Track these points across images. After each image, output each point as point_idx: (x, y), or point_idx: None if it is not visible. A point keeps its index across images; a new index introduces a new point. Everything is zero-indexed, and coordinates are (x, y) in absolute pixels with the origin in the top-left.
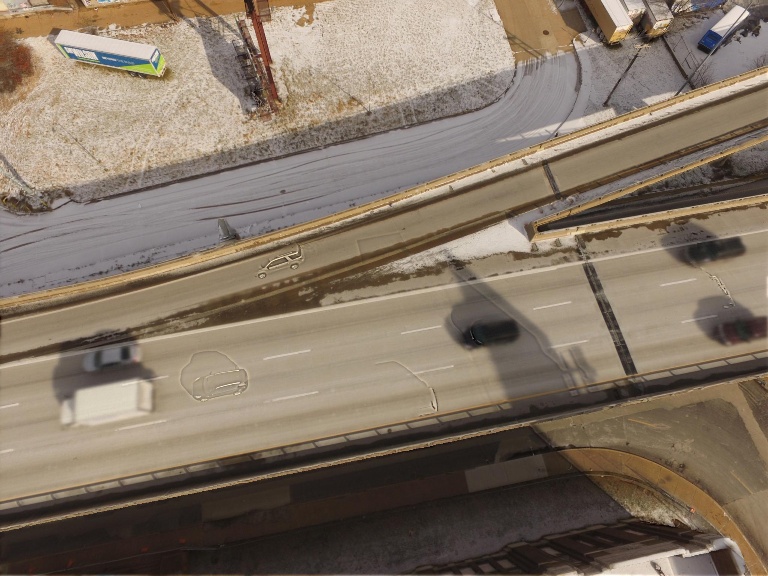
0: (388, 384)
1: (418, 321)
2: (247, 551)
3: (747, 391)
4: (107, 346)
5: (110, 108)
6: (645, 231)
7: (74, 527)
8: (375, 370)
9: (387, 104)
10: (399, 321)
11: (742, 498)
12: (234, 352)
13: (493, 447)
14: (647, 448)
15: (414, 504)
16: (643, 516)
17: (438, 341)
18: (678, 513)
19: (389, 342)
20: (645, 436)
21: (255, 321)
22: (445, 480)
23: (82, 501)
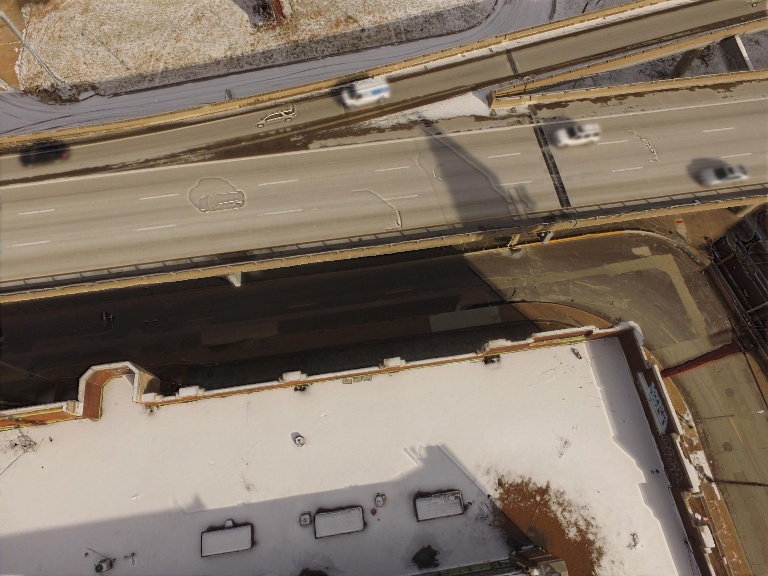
0: (361, 206)
1: (390, 162)
2: (238, 368)
3: (681, 264)
4: (128, 171)
5: (133, 18)
6: (589, 104)
7: (91, 346)
8: (351, 196)
9: (380, 23)
10: (374, 162)
11: (668, 346)
12: (234, 179)
13: (455, 299)
14: (589, 304)
15: (384, 339)
16: None
17: (405, 177)
18: None
19: (364, 177)
20: (588, 295)
21: (253, 158)
22: (412, 322)
23: (105, 278)
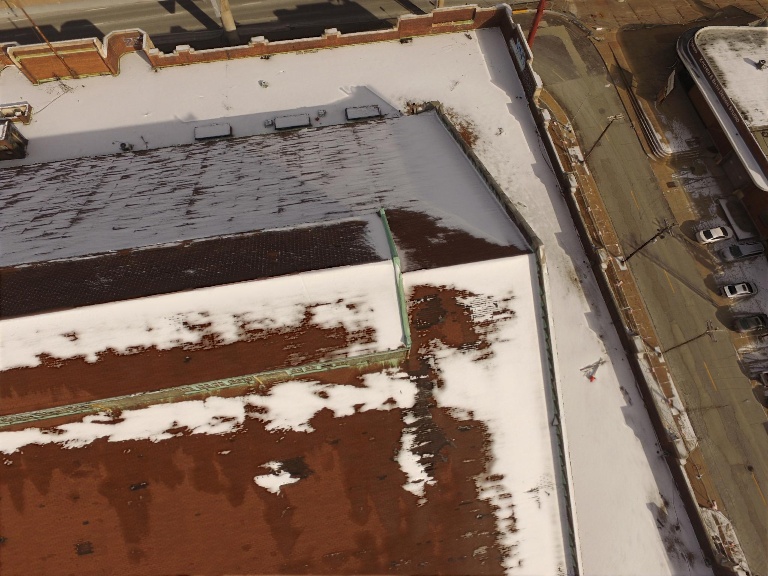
0: None
1: None
2: None
3: (571, 31)
4: None
5: None
6: None
7: None
8: None
9: None
10: None
11: (557, 83)
12: None
13: None
14: None
15: None
16: None
17: None
18: None
19: None
20: None
21: None
22: None
23: None
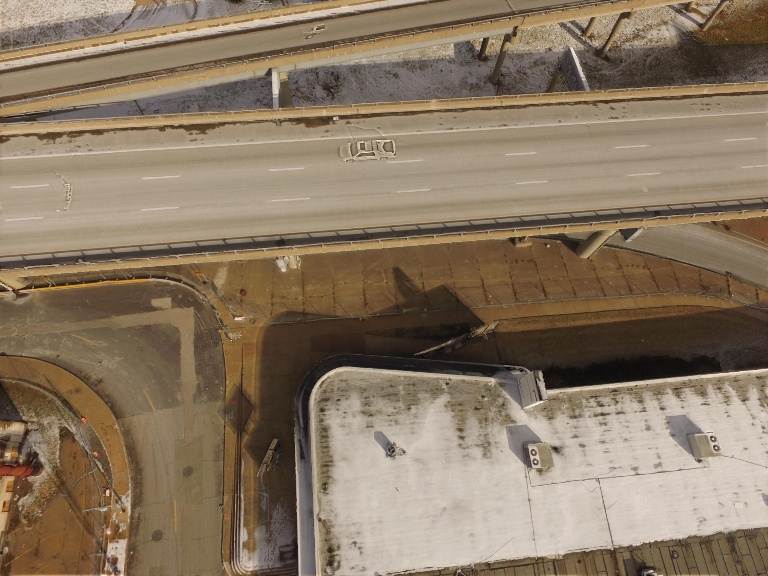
0: None
1: None
2: None
3: (199, 319)
4: None
5: None
6: (33, 140)
7: None
8: None
9: None
10: None
11: (142, 414)
12: None
13: None
14: (74, 361)
15: None
16: (34, 421)
17: None
18: (69, 421)
19: None
20: (78, 350)
21: None
22: None
23: None
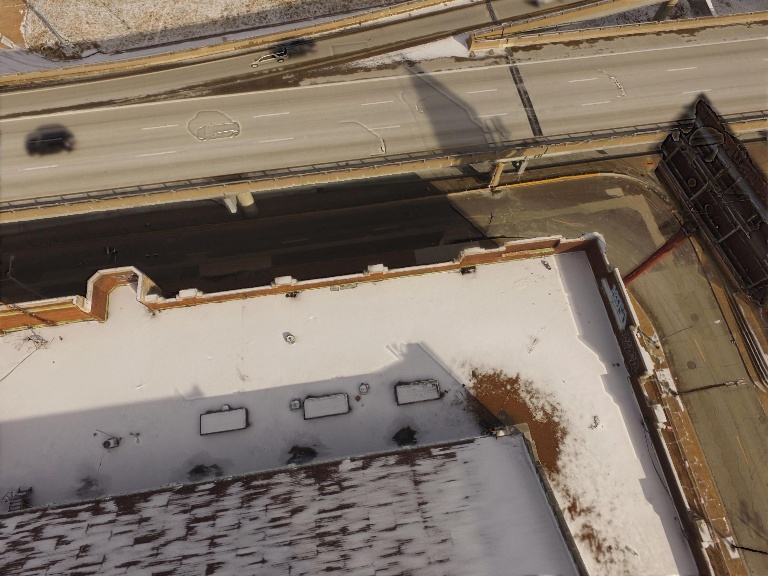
0: (348, 135)
1: (375, 97)
2: None
3: (651, 203)
4: (131, 105)
5: None
6: (562, 47)
7: None
8: (339, 126)
9: None
10: (360, 97)
11: (638, 276)
12: (230, 112)
13: (439, 235)
14: None
15: None
16: None
17: (390, 110)
18: None
19: (351, 110)
20: (564, 231)
21: (247, 93)
22: (398, 255)
23: None
